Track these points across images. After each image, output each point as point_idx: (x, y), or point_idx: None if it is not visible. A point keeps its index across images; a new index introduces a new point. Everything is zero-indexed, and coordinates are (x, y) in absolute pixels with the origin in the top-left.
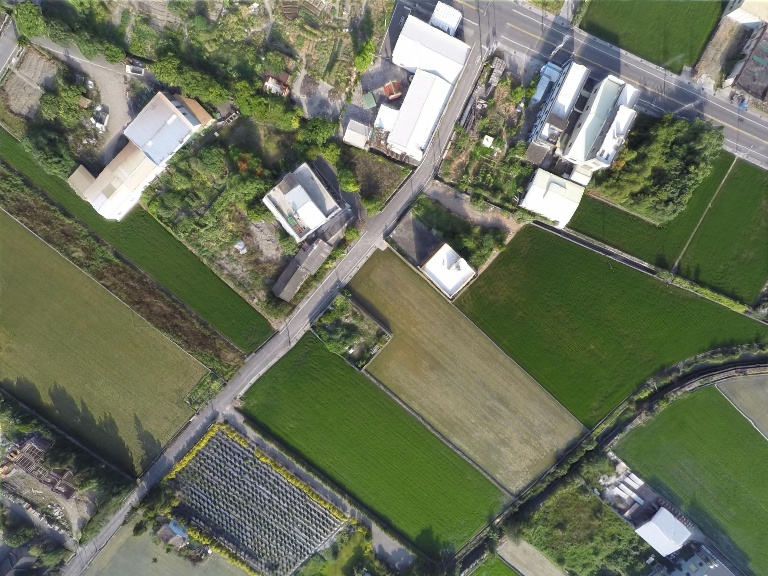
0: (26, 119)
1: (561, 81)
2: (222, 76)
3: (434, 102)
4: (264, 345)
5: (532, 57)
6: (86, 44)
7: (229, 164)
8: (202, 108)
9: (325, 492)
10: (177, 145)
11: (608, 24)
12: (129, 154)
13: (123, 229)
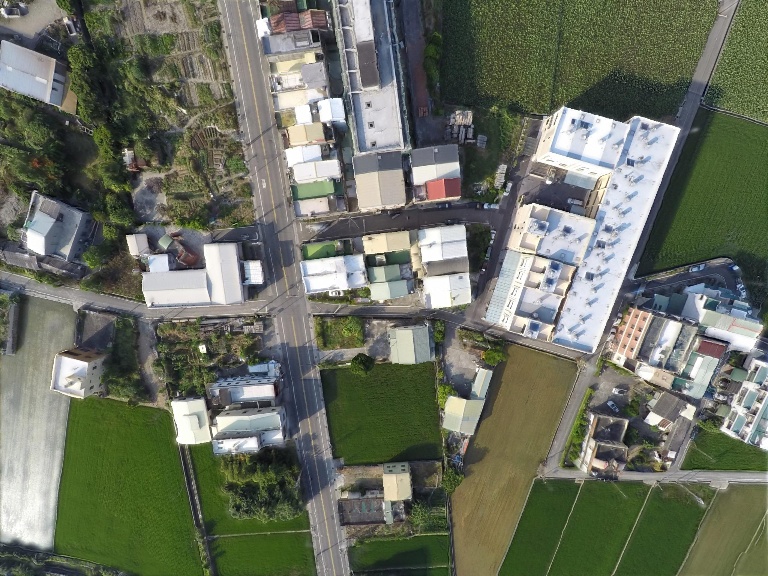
0: None
1: (260, 382)
2: (108, 109)
3: (189, 295)
4: None
5: (282, 348)
6: None
7: (43, 147)
8: (76, 101)
9: None
10: (25, 94)
11: (337, 389)
12: None
13: None
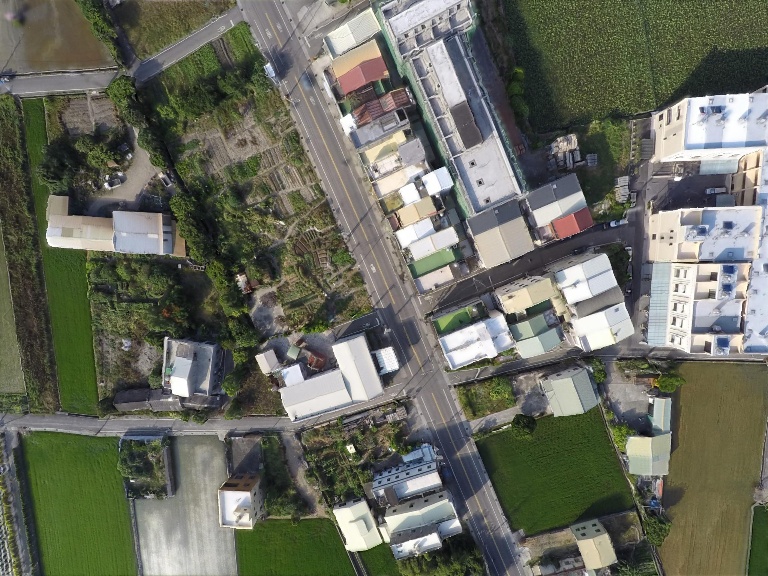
0: (65, 132)
1: (421, 472)
2: (215, 243)
3: (330, 400)
4: (80, 416)
5: (429, 428)
6: (143, 140)
7: (165, 295)
8: (184, 245)
9: (25, 546)
10: (141, 253)
11: (497, 457)
12: (104, 225)
13: (60, 254)
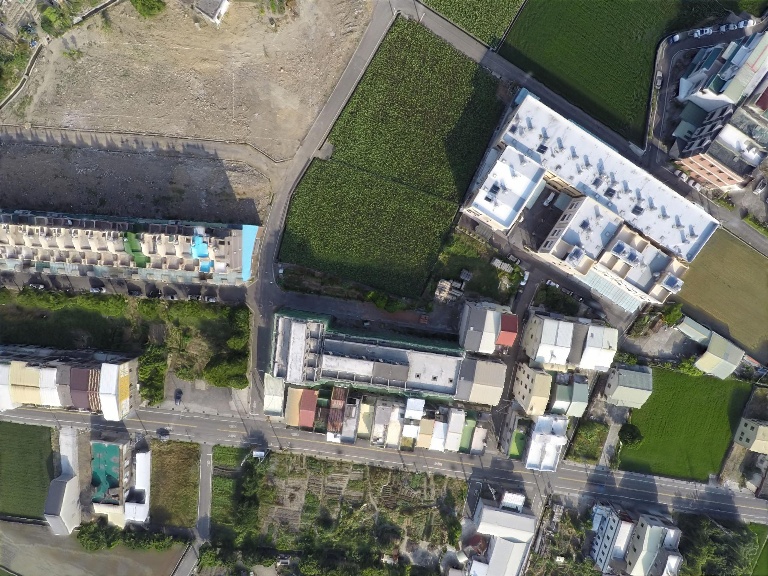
0: None
1: (614, 530)
2: (349, 560)
3: (515, 558)
4: None
5: (583, 495)
6: (250, 565)
7: None
8: None
9: None
10: None
11: (640, 460)
12: None
13: None
